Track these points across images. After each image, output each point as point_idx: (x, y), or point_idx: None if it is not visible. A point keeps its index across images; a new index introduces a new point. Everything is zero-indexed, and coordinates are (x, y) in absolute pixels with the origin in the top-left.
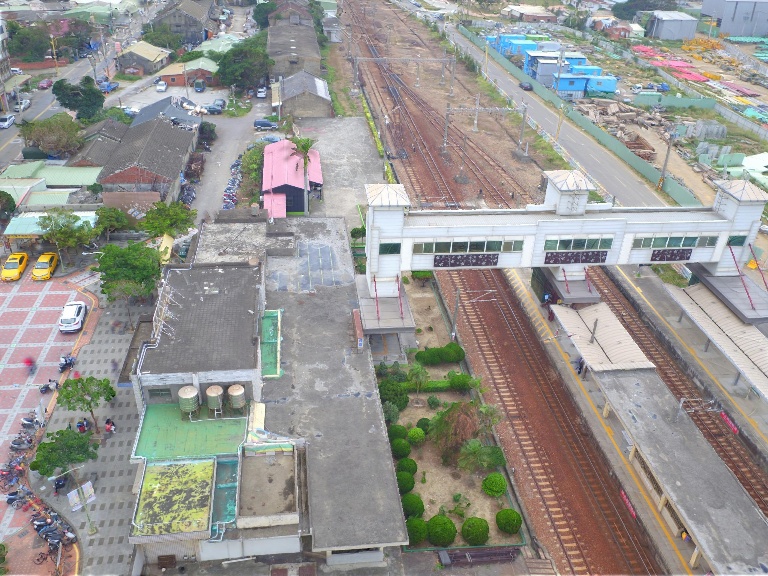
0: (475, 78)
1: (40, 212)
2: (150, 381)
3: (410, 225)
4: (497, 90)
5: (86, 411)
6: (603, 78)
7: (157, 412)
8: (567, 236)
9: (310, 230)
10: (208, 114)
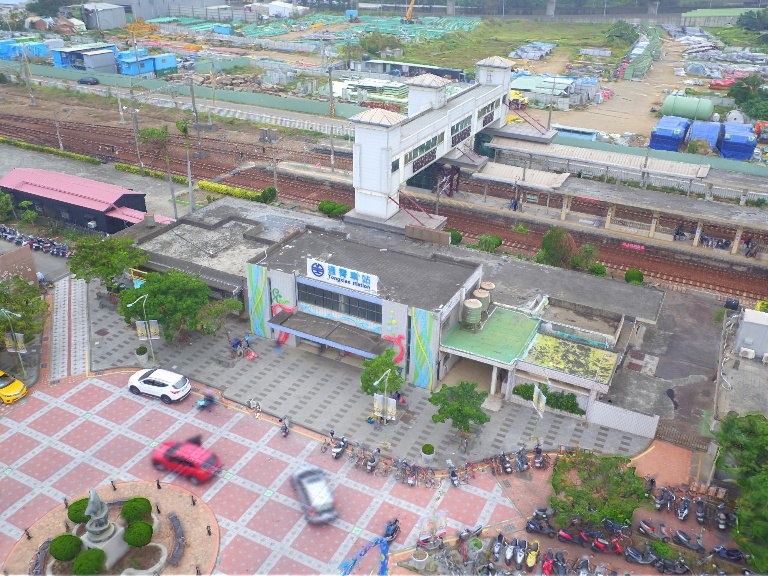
0: (22, 87)
1: None
2: (444, 313)
3: None
4: (73, 89)
5: (350, 414)
6: (165, 55)
7: (453, 342)
8: (458, 120)
9: (226, 214)
10: None
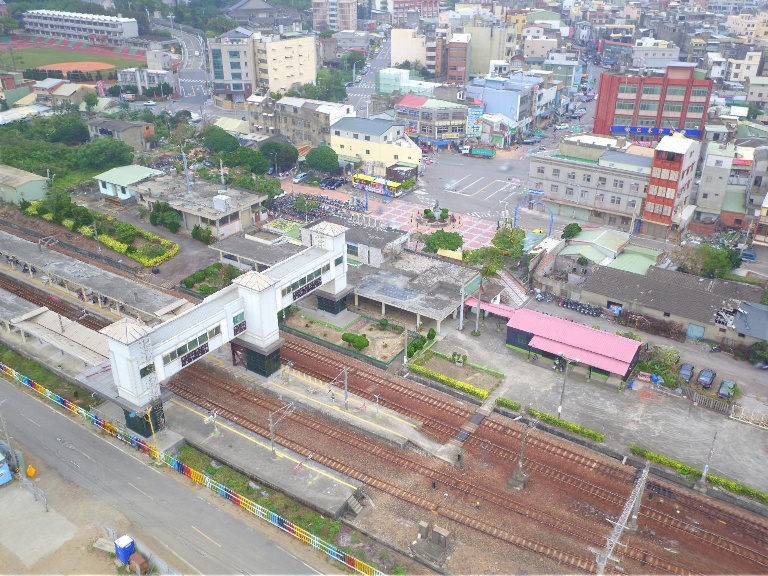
0: None
1: None
2: None
3: (316, 249)
4: None
5: None
6: None
7: None
8: None
9: (436, 302)
10: None
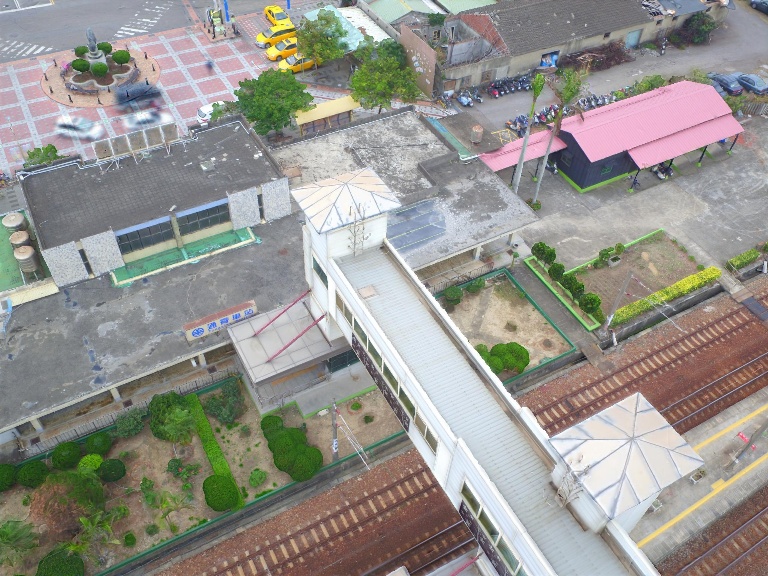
0: None
1: (364, 13)
2: None
3: (350, 265)
4: None
5: None
6: None
7: None
8: (492, 517)
9: (475, 199)
10: (729, 8)
